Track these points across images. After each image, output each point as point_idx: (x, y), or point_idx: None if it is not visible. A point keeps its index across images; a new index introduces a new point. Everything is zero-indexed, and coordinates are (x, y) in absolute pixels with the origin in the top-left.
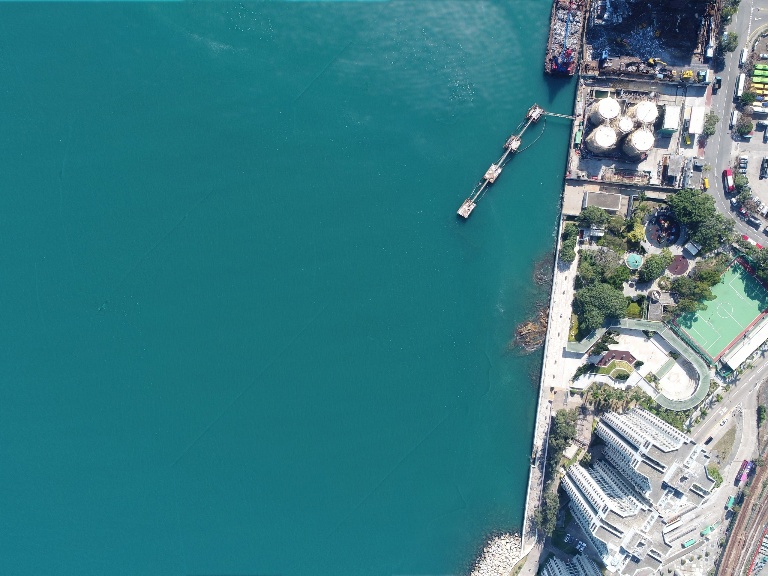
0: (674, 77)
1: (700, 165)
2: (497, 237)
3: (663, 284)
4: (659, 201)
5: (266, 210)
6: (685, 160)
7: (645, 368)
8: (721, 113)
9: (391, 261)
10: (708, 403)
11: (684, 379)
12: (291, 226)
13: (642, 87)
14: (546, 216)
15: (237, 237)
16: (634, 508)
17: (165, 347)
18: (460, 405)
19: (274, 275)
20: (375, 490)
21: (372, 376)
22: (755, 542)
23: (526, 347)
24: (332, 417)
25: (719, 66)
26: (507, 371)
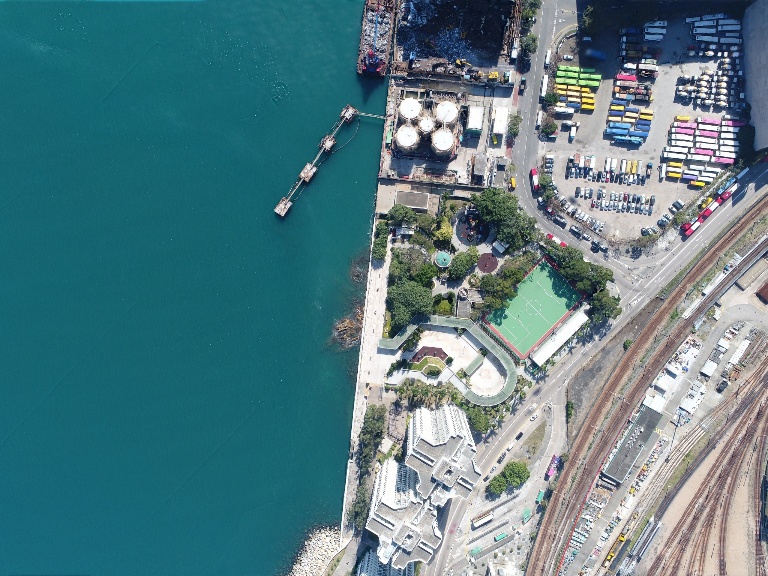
0: (481, 78)
1: (503, 165)
2: (315, 235)
3: (473, 282)
4: (468, 200)
5: (75, 208)
6: (493, 160)
7: (457, 364)
8: (528, 113)
9: (196, 258)
10: (518, 399)
11: (495, 375)
12: (99, 224)
13: (451, 88)
14: (361, 215)
15: (47, 235)
16: (407, 501)
17: None
18: (267, 400)
19: (83, 272)
20: (185, 484)
21: (181, 372)
22: (565, 536)
23: (344, 343)
24: (143, 412)
25: (525, 67)
26: (326, 367)
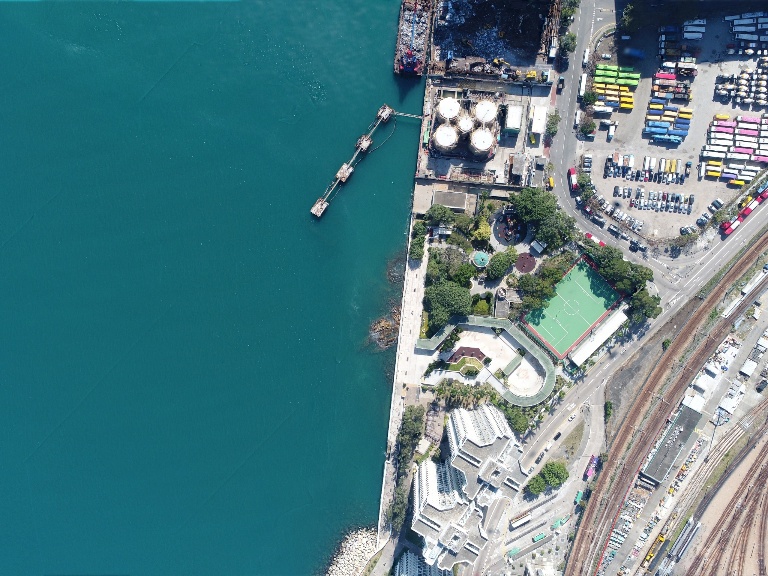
0: (519, 77)
1: (542, 164)
2: (351, 235)
3: (511, 282)
4: (506, 200)
5: (113, 209)
6: (531, 159)
7: (494, 365)
8: (566, 113)
9: (235, 259)
10: (556, 399)
11: (533, 375)
12: (137, 225)
13: (488, 87)
14: (397, 215)
15: (85, 236)
16: (453, 502)
17: (16, 344)
18: (306, 401)
19: (121, 273)
20: (223, 485)
21: (220, 373)
22: (603, 536)
23: (380, 344)
24: (181, 413)
25: (563, 66)
26: (362, 368)
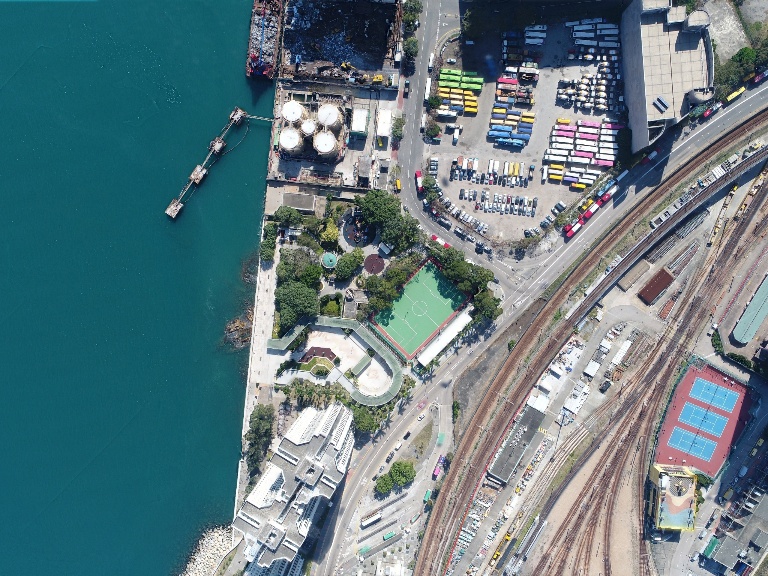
0: (367, 81)
1: (385, 167)
2: (207, 236)
3: (360, 283)
4: None
5: None
6: None
7: (345, 365)
8: (412, 116)
9: (81, 259)
10: (405, 399)
11: (382, 375)
12: None
13: (338, 91)
14: (251, 216)
15: None
16: None
17: None
18: (152, 400)
19: None
20: (71, 483)
21: (68, 371)
22: (452, 535)
23: (235, 344)
24: (30, 411)
25: (409, 70)
26: (218, 367)
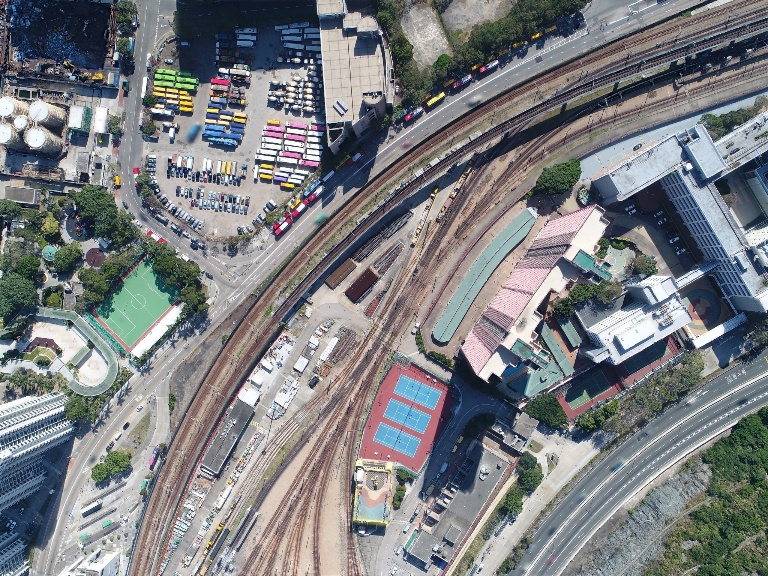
0: (89, 79)
1: (99, 163)
2: None
3: None
4: None
5: None
6: None
7: (67, 355)
8: (132, 114)
9: None
10: (124, 390)
11: (103, 367)
12: None
13: (62, 88)
14: None
15: None
16: None
17: None
18: None
19: None
20: None
21: None
22: (167, 524)
23: None
24: None
25: (129, 70)
26: None
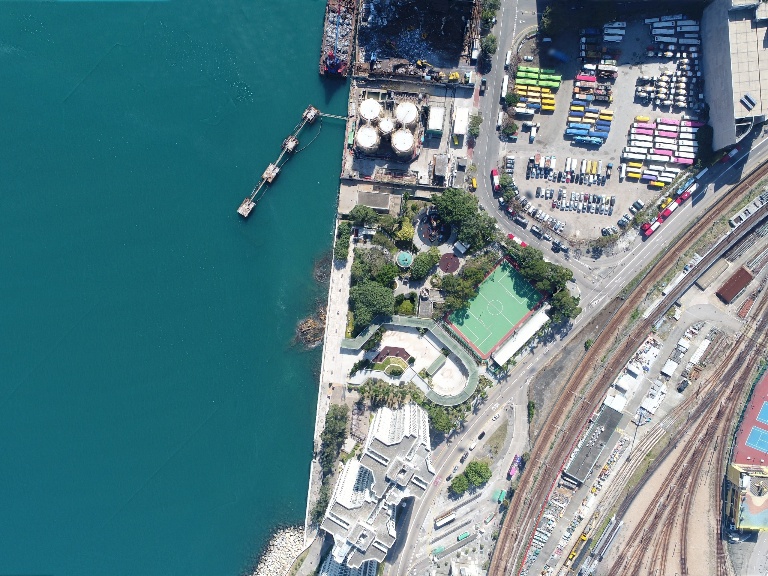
0: (442, 79)
1: (463, 165)
2: (278, 235)
3: (435, 282)
4: (429, 200)
5: (36, 209)
6: (454, 160)
7: (419, 364)
8: (488, 114)
9: (157, 259)
10: (480, 399)
11: (457, 375)
12: (60, 224)
13: (412, 88)
14: (323, 215)
15: (9, 235)
16: (362, 500)
17: None
18: (228, 400)
19: (45, 272)
20: (147, 483)
21: (143, 372)
22: (527, 535)
23: (307, 344)
24: (105, 412)
25: (486, 68)
26: (289, 367)
